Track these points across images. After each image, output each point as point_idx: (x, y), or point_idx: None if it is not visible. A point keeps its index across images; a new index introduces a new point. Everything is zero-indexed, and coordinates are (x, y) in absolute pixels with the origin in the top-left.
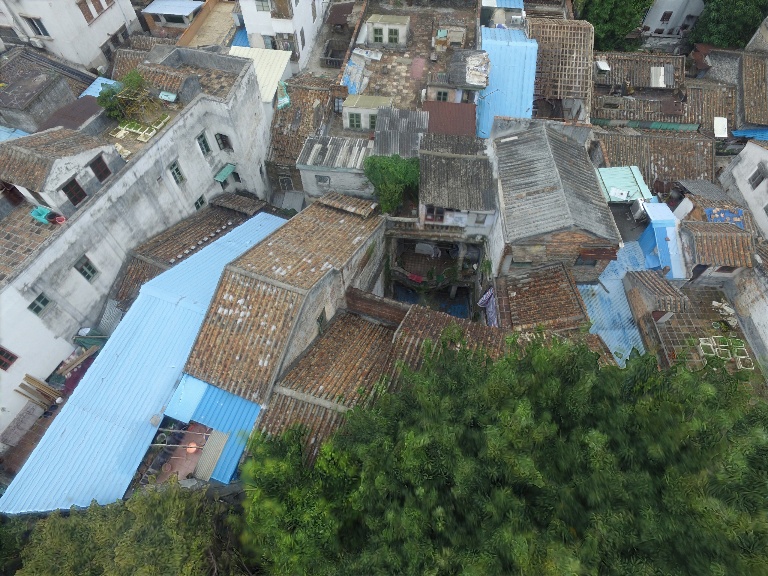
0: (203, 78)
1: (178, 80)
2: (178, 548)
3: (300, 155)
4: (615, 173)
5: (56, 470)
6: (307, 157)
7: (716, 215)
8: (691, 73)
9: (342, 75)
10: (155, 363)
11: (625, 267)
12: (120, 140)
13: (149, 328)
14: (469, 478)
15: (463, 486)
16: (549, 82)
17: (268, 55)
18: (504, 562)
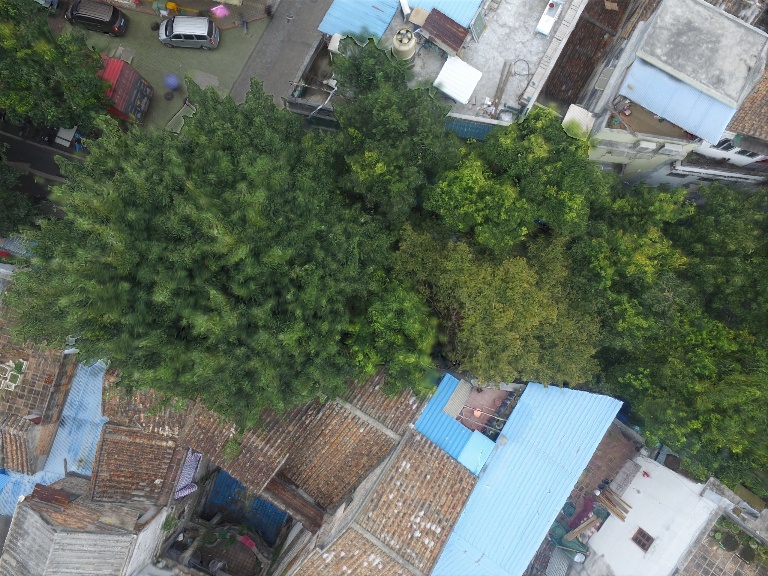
0: None
1: None
2: (478, 333)
3: None
4: None
5: (580, 421)
6: None
7: None
8: None
9: None
10: (504, 495)
11: (30, 484)
12: None
13: (510, 535)
14: None
15: (266, 308)
16: None
17: None
18: (257, 257)
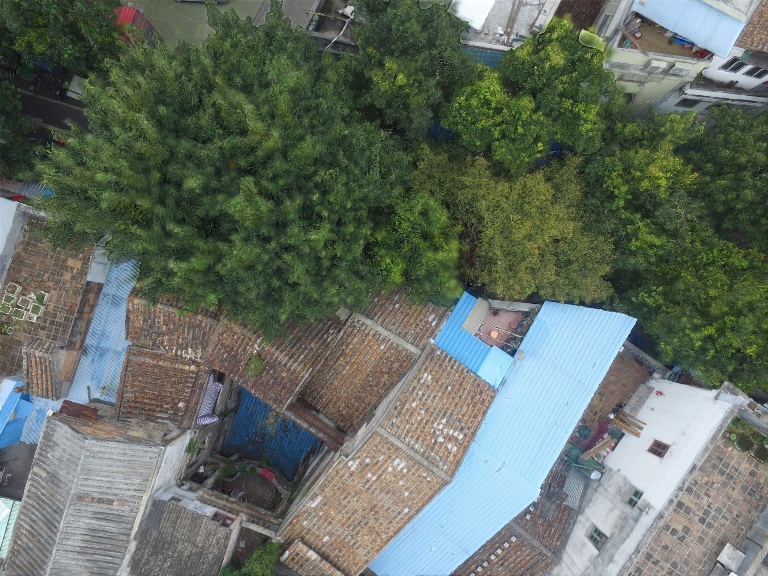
0: None
1: None
2: (497, 245)
3: None
4: None
5: (596, 337)
6: None
7: None
8: None
9: None
10: (523, 408)
11: (54, 411)
12: None
13: (529, 445)
14: None
15: (294, 205)
16: None
17: None
18: (285, 155)
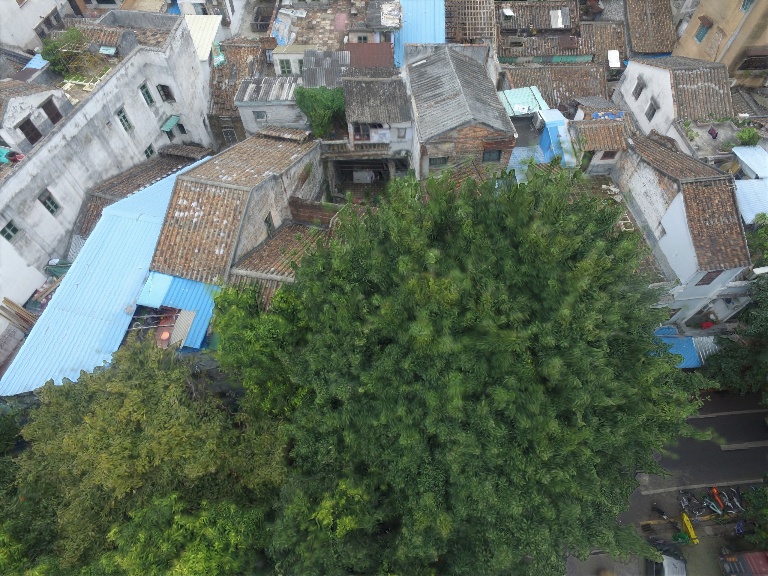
0: (139, 36)
1: (116, 35)
2: (160, 380)
3: (237, 94)
4: (518, 93)
5: (45, 359)
6: (243, 95)
7: (602, 118)
8: (589, 18)
9: (271, 31)
10: (123, 267)
11: None
12: (67, 91)
13: (114, 241)
14: (383, 271)
15: (378, 276)
16: (458, 25)
17: (200, 20)
18: (408, 312)
